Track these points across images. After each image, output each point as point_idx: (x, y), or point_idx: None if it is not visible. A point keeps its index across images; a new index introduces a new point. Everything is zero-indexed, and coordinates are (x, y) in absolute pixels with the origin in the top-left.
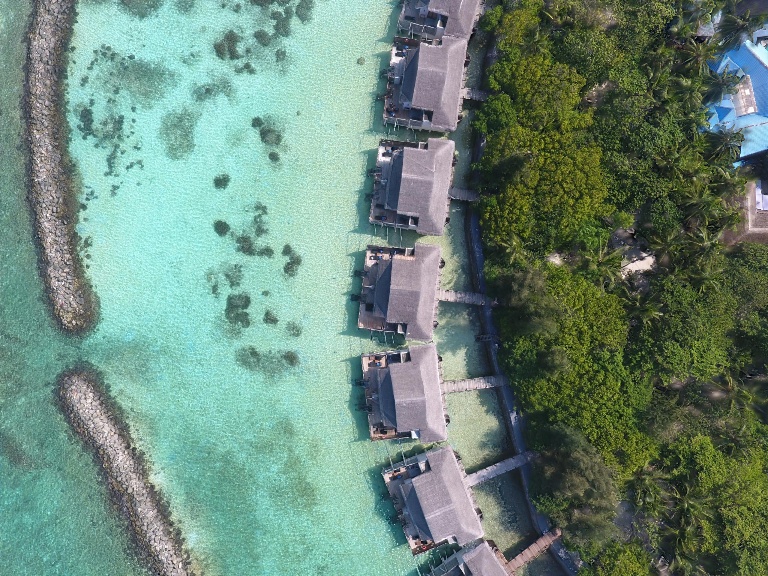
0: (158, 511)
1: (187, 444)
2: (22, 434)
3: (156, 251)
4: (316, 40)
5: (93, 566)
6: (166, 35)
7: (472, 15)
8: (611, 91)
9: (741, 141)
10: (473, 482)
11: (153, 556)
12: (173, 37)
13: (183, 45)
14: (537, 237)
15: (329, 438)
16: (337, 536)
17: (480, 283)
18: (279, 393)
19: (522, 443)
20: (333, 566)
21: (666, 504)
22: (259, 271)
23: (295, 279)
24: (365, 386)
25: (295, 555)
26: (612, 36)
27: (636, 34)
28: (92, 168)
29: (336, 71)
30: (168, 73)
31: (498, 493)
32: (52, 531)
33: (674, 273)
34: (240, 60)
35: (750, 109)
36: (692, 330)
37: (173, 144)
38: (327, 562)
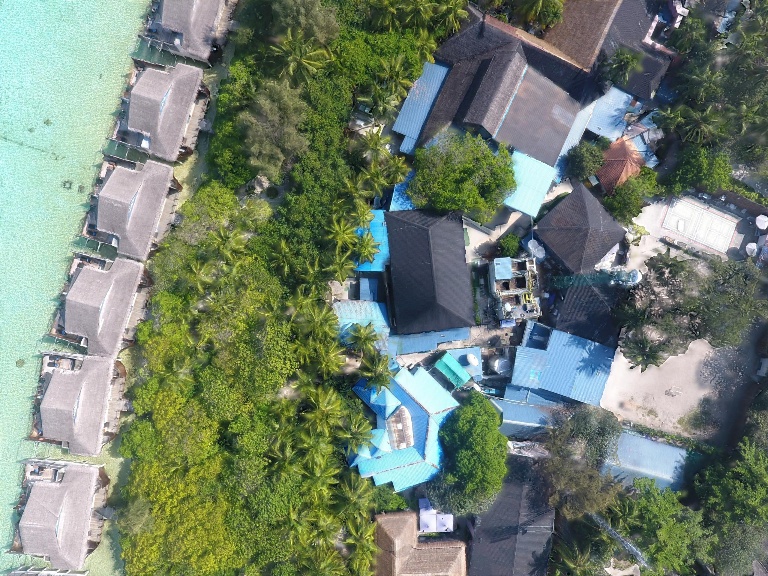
0: None
1: None
2: None
3: None
4: None
5: None
6: None
7: (118, 333)
8: None
9: (359, 510)
10: None
11: None
12: None
13: None
14: None
15: None
16: None
17: None
18: None
19: None
20: None
21: None
22: None
23: None
24: None
25: None
26: (236, 384)
27: (256, 387)
28: None
29: None
30: None
31: None
32: None
33: None
34: None
35: (402, 445)
36: None
37: None
38: None
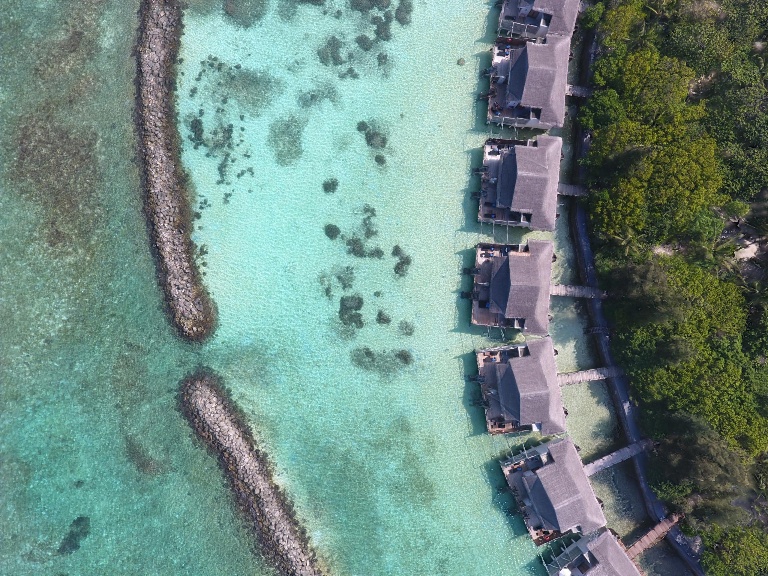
0: (283, 511)
1: (308, 444)
2: (148, 440)
3: (270, 256)
4: (416, 43)
5: (222, 567)
6: (270, 44)
7: (574, 13)
8: (722, 83)
9: None
10: (590, 472)
11: (281, 555)
12: (277, 45)
13: (287, 53)
14: (652, 229)
15: (445, 434)
16: (457, 530)
17: (588, 276)
18: (395, 391)
19: (636, 432)
20: (454, 559)
21: None
22: (370, 272)
23: (406, 279)
24: (481, 381)
25: (417, 549)
26: (722, 28)
27: (747, 25)
28: (204, 177)
29: (437, 73)
30: (274, 81)
31: (612, 482)
32: (181, 534)
33: None
34: (343, 65)
35: None
36: None
37: (282, 150)
38: (448, 555)
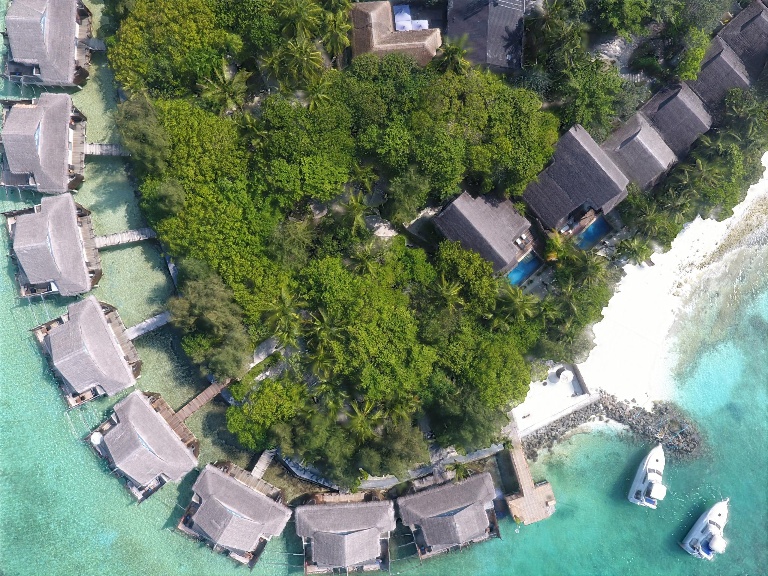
0: None
1: None
2: None
3: None
4: None
5: None
6: None
7: None
8: None
9: None
10: (132, 335)
11: None
12: None
13: None
14: (153, 71)
15: None
16: (5, 403)
17: None
18: None
19: None
20: (4, 434)
21: (303, 331)
22: None
23: None
24: None
25: None
26: None
27: None
28: None
29: None
30: None
31: (170, 348)
32: None
33: (280, 90)
34: None
35: None
36: (293, 143)
37: None
38: None
